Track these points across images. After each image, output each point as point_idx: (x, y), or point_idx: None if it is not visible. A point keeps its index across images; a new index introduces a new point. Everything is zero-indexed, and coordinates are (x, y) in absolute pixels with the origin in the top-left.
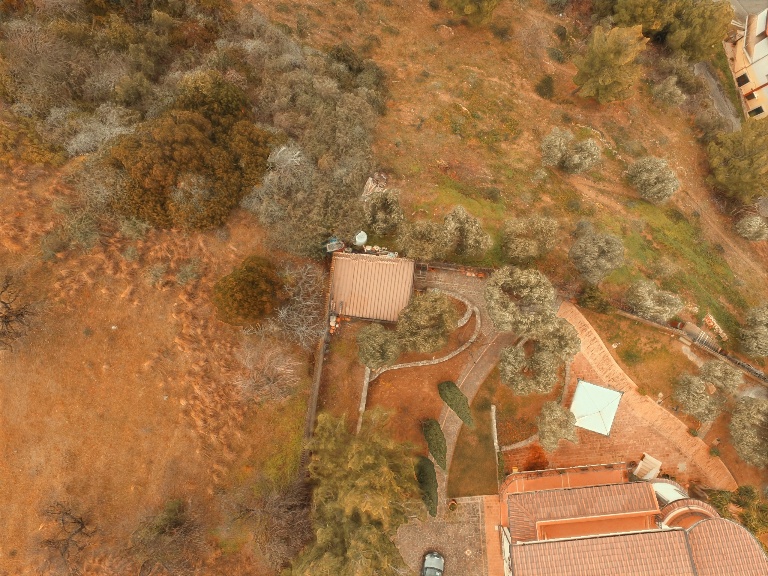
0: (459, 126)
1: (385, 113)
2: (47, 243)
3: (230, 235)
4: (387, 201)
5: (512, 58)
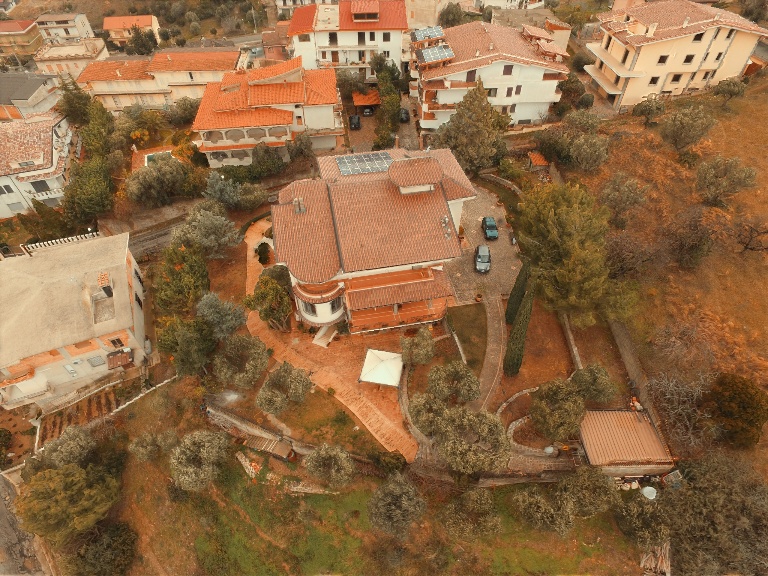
0: None
1: None
2: None
3: None
4: None
5: None
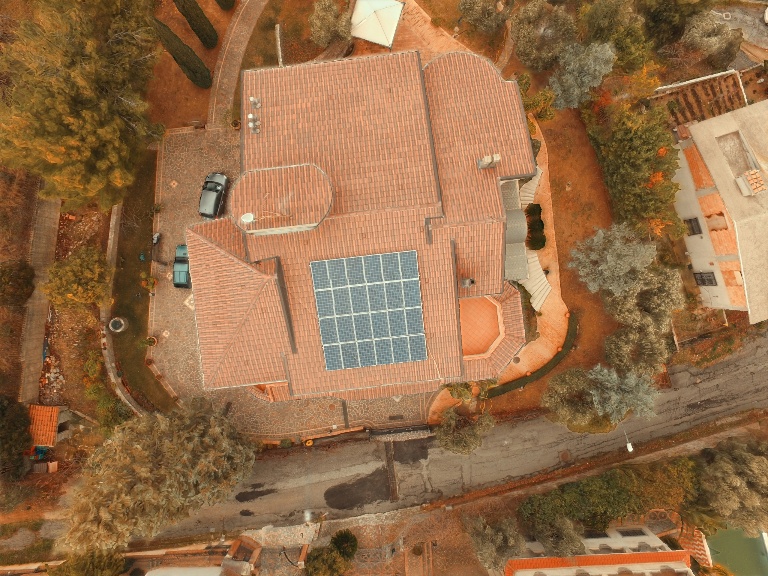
0: None
1: None
2: None
3: None
4: None
5: None
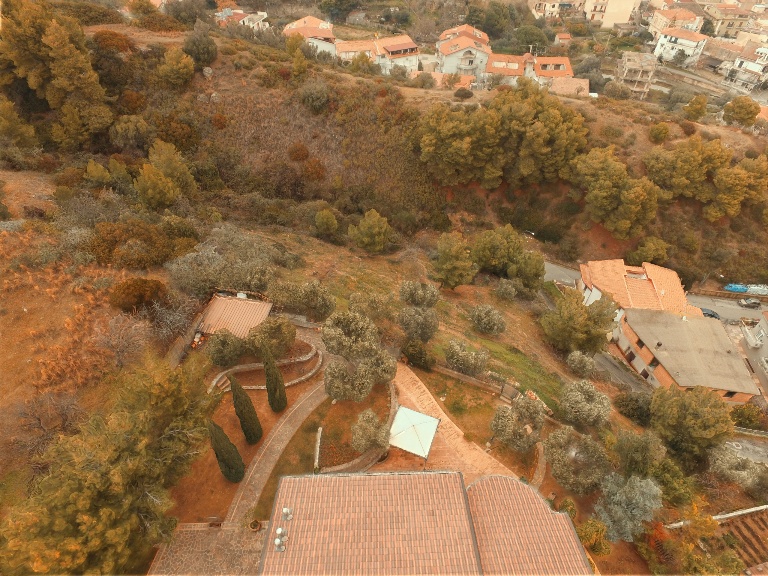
0: (345, 282)
1: (294, 268)
2: (20, 257)
3: (147, 276)
4: (266, 273)
5: (398, 272)
